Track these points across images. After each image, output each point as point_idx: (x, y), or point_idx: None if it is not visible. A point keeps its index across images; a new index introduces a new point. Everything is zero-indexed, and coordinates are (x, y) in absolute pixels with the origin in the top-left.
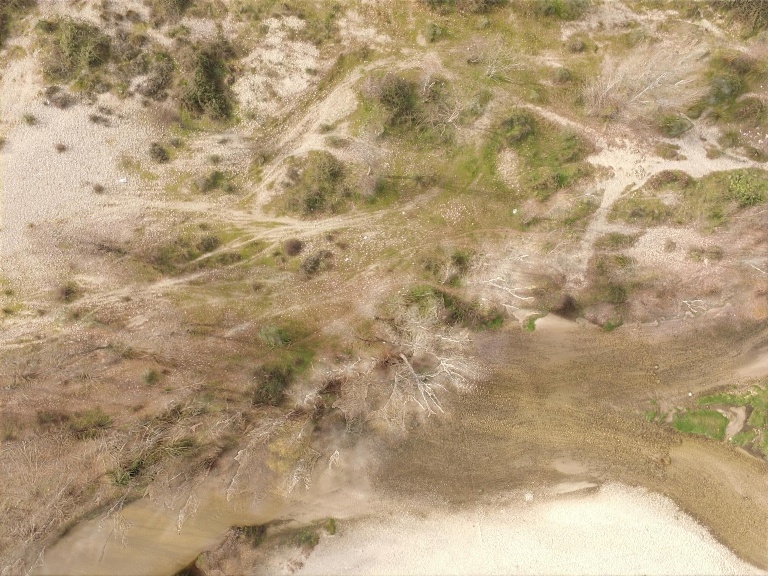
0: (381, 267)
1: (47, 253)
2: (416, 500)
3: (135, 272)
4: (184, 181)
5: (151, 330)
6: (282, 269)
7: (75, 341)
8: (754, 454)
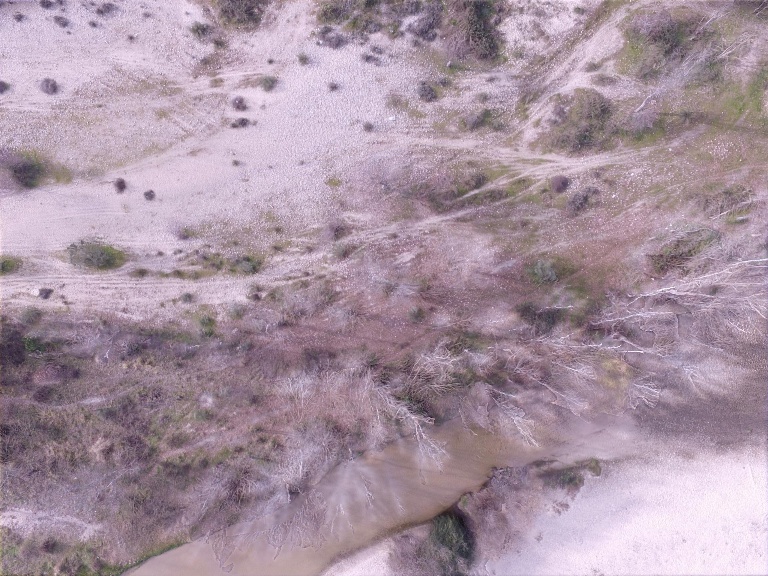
0: (648, 204)
1: (317, 190)
2: (683, 441)
3: (403, 209)
4: (452, 119)
5: (417, 267)
6: (549, 206)
7: (342, 278)
8: None
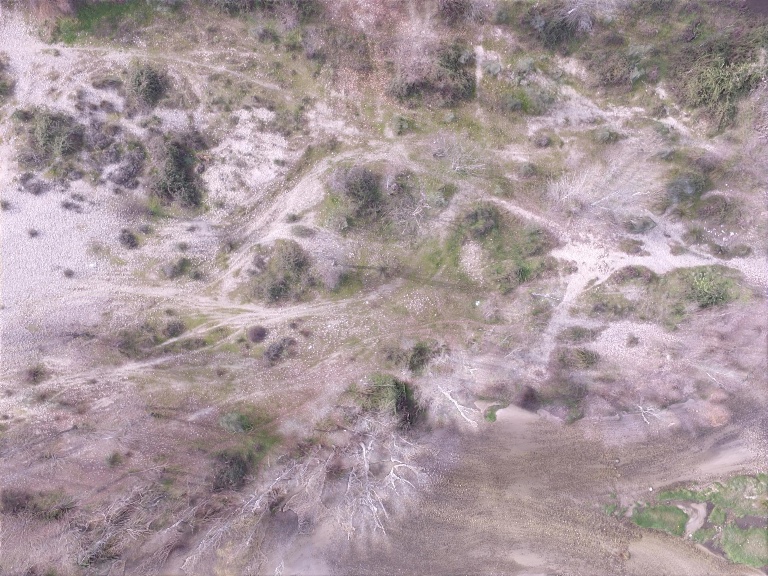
0: (344, 355)
1: (17, 335)
2: None
3: (102, 355)
4: (152, 267)
5: (116, 412)
6: (246, 355)
7: (42, 421)
8: (714, 551)
